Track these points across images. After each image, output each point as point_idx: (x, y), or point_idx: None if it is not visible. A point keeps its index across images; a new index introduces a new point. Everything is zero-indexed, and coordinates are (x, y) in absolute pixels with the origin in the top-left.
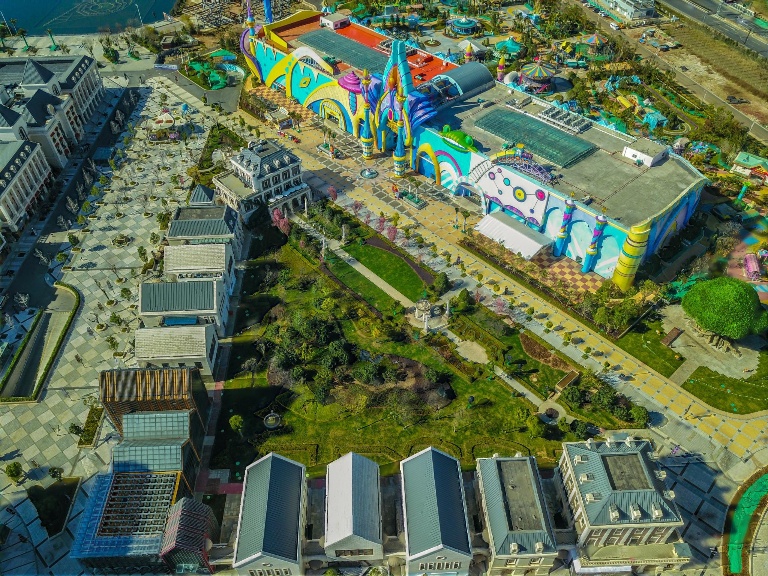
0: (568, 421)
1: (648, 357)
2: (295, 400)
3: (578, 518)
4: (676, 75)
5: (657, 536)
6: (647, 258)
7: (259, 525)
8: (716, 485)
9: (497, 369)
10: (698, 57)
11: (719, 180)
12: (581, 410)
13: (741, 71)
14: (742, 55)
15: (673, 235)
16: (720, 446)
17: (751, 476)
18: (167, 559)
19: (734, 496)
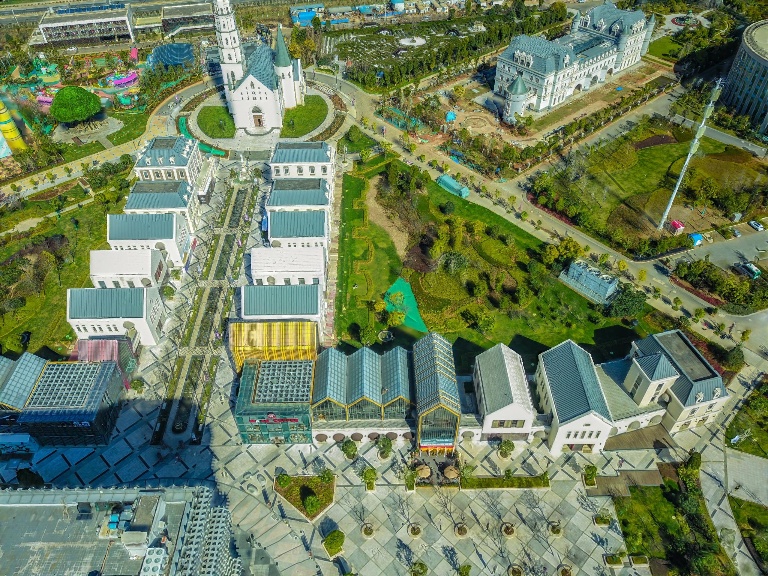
0: (113, 190)
1: (87, 152)
2: (7, 324)
3: (179, 179)
4: None
5: (199, 160)
6: None
7: (123, 295)
8: None
9: (52, 214)
10: None
11: None
12: (108, 184)
13: None
14: None
15: None
16: None
17: None
18: (121, 367)
19: None
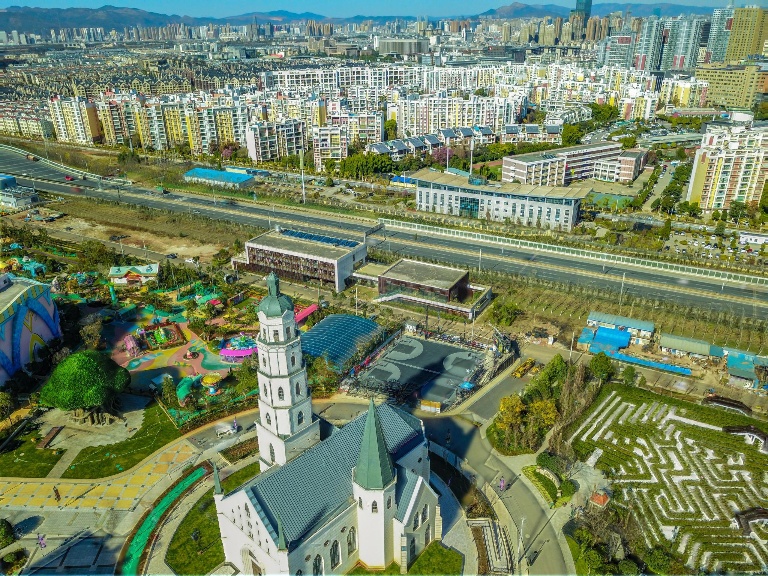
0: None
1: (20, 469)
2: None
3: None
4: (60, 235)
5: None
6: (13, 378)
7: None
8: (102, 551)
9: None
10: (82, 218)
11: (97, 294)
12: None
13: (121, 218)
14: (122, 209)
15: (38, 347)
16: (105, 511)
17: (139, 520)
18: None
19: (121, 550)
